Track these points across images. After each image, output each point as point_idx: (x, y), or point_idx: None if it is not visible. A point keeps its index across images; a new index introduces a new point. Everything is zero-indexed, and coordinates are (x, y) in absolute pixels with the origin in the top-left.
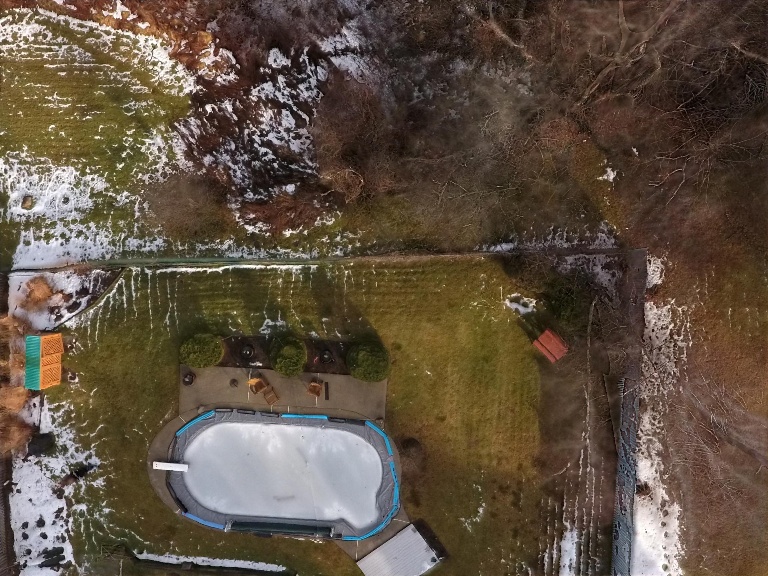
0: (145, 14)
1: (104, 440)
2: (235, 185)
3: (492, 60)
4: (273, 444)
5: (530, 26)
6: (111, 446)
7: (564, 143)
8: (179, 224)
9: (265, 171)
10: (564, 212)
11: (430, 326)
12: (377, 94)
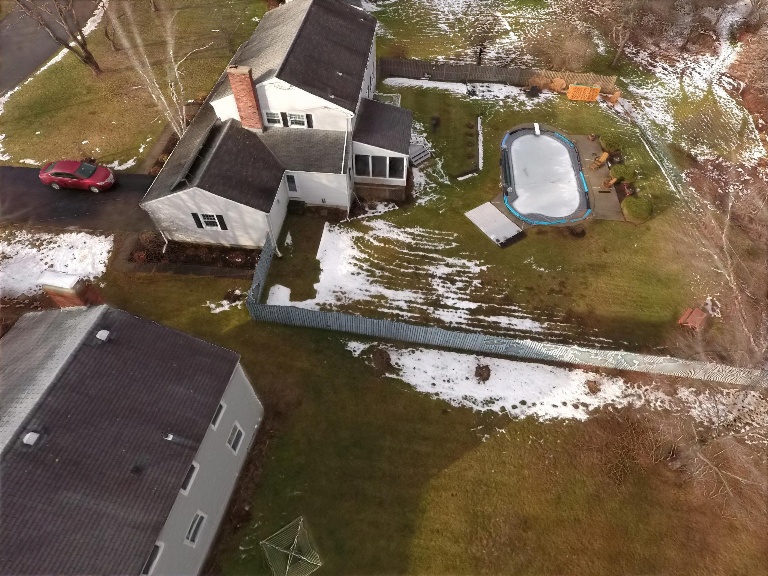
0: None
1: None
2: (705, 172)
3: None
4: (560, 169)
5: None
6: (540, 112)
7: None
8: (669, 150)
9: None
10: None
11: (671, 247)
12: None
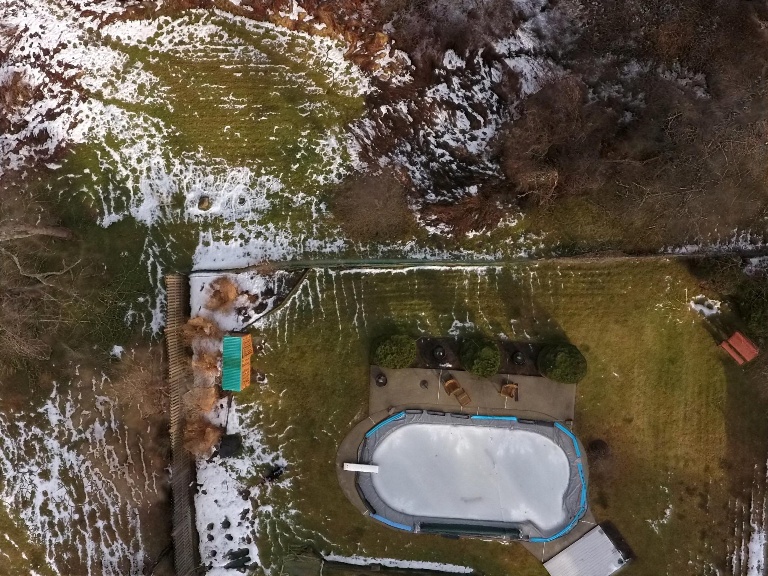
0: (324, 15)
1: (292, 441)
2: (415, 186)
3: (667, 62)
4: (461, 445)
5: (705, 29)
6: (299, 447)
7: (747, 145)
8: (359, 225)
9: (444, 172)
10: (748, 214)
11: (617, 328)
12: None
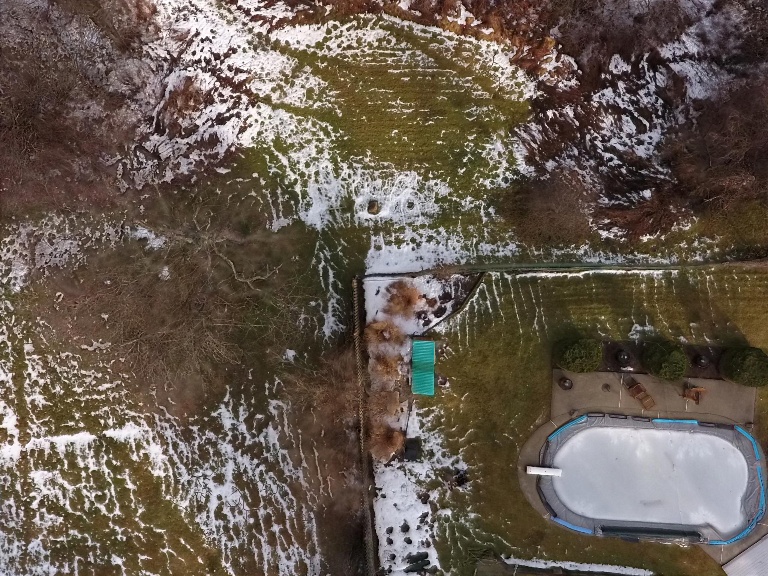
0: (493, 20)
1: (473, 445)
2: (586, 190)
3: None
4: (641, 448)
5: None
6: (480, 451)
7: None
8: (531, 229)
9: (614, 176)
10: None
11: None
12: (715, 100)
